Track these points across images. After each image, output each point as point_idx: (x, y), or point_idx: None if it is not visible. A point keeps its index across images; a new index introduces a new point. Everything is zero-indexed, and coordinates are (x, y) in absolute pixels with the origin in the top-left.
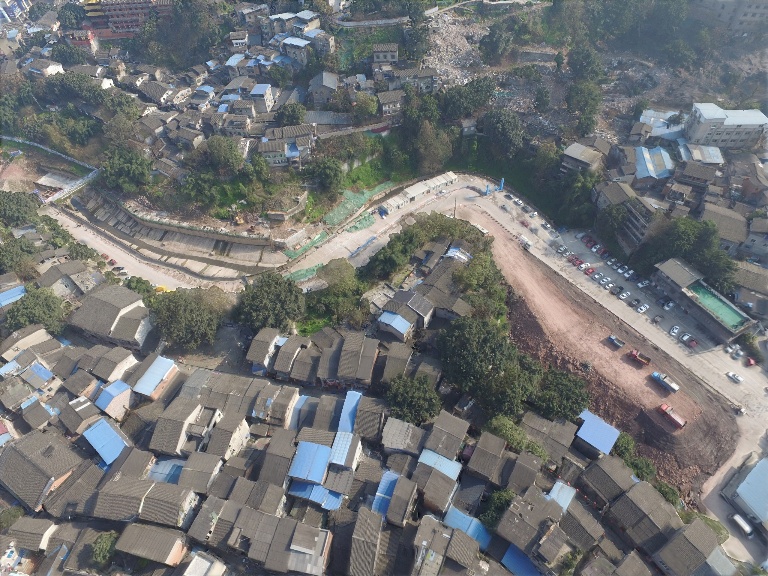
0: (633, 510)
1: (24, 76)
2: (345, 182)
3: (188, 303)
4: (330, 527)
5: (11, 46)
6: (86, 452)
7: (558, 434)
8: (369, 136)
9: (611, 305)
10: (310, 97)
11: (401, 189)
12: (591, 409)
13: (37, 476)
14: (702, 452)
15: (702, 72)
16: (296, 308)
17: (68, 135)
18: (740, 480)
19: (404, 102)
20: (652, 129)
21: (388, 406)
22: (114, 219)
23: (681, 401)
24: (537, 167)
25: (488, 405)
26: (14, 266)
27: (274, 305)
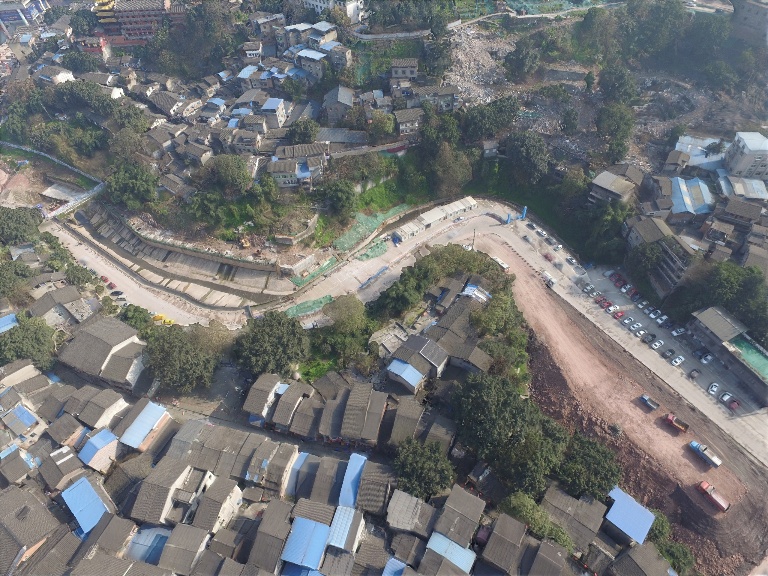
0: None
1: (34, 83)
2: (358, 204)
3: (183, 344)
4: None
5: (24, 51)
6: (65, 511)
7: (585, 515)
8: (384, 156)
9: (642, 355)
10: (324, 113)
11: (416, 213)
12: (620, 479)
13: (8, 543)
14: (747, 538)
15: (745, 96)
16: (299, 351)
17: (75, 146)
18: None
19: (422, 121)
20: (689, 158)
21: (395, 475)
22: (117, 236)
23: (723, 477)
24: (563, 195)
25: (506, 476)
26: (7, 292)
27: (275, 349)
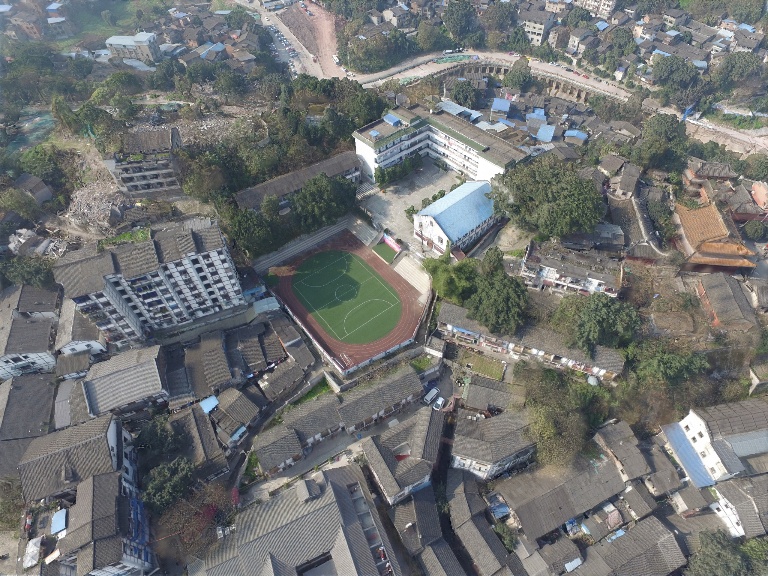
0: None
1: None
2: None
3: (497, 3)
4: None
5: None
6: None
7: None
8: None
9: (292, 37)
10: None
11: None
12: None
13: None
14: None
15: None
16: None
17: None
18: None
19: None
20: None
21: None
22: None
23: None
24: None
25: None
26: None
27: None
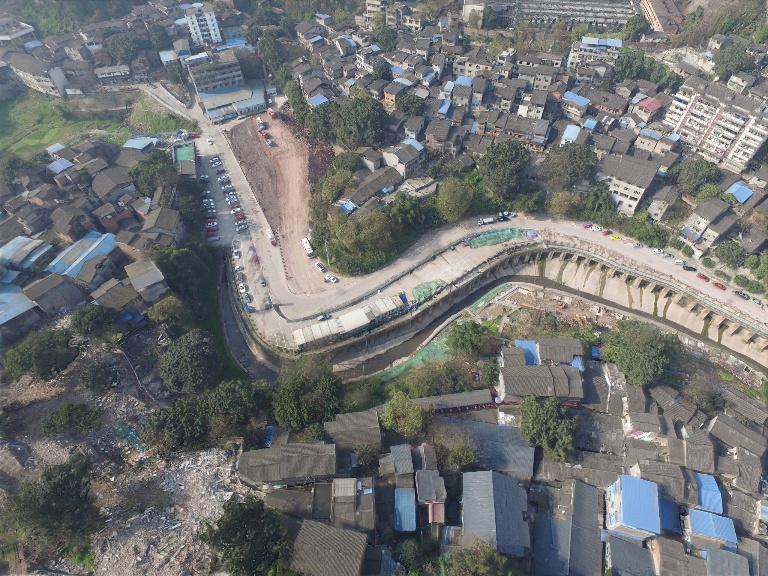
0: (322, 80)
1: None
2: None
3: None
4: (454, 77)
5: None
6: (590, 113)
7: (338, 101)
8: None
9: (243, 183)
10: None
11: (369, 370)
12: None
13: None
14: None
15: None
16: None
17: None
18: (255, 112)
19: None
20: None
21: None
22: None
23: None
24: None
25: None
26: None
27: None
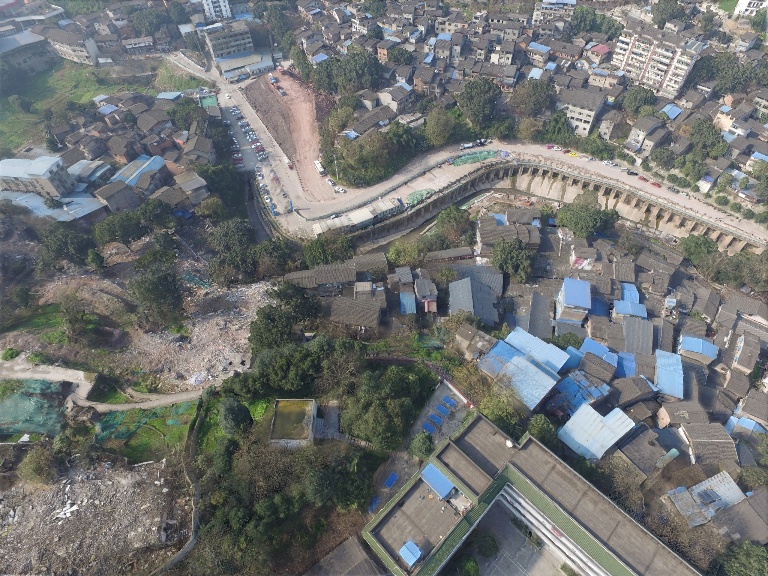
0: None
1: None
2: None
3: (530, 82)
4: None
5: None
6: (552, 60)
7: None
8: None
9: (260, 126)
10: None
11: None
12: None
13: None
14: None
15: None
16: None
17: None
18: (265, 73)
19: None
20: None
21: None
22: None
23: None
24: None
25: None
26: None
27: None
